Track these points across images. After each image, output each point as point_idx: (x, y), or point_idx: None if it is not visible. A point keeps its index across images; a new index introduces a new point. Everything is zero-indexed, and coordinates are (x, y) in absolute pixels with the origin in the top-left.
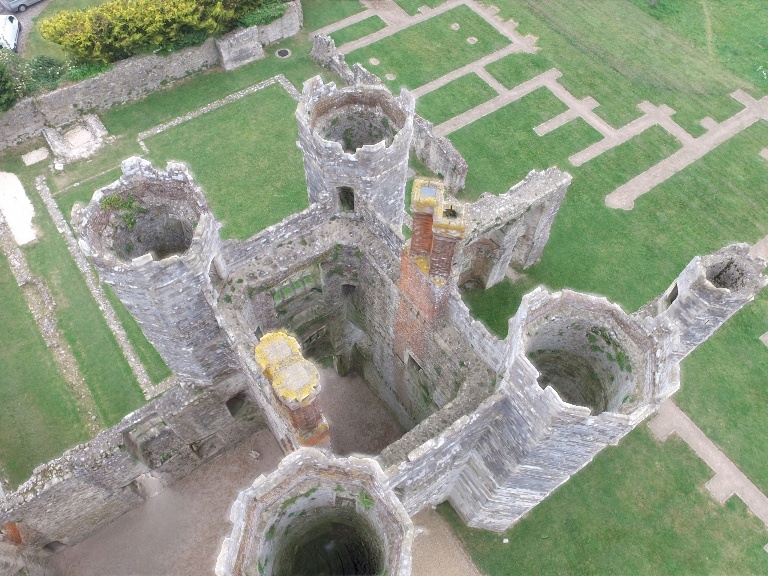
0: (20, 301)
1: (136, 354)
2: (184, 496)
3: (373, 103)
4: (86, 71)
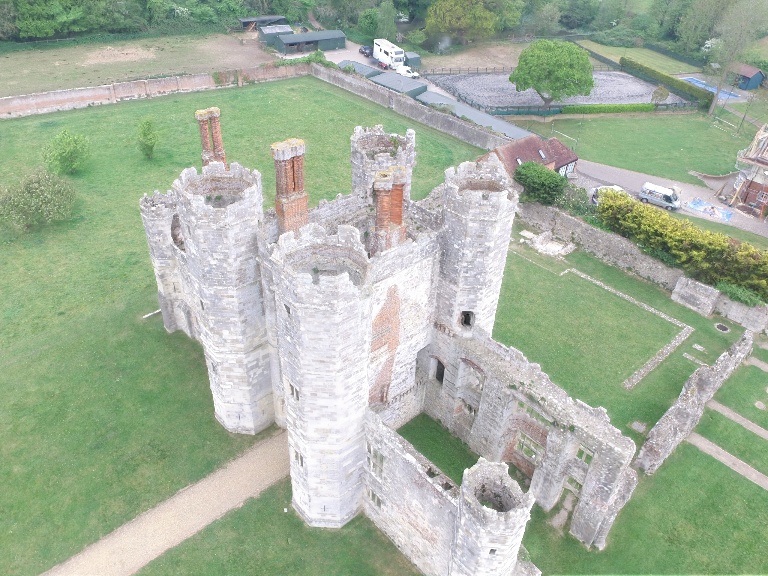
0: None
1: None
2: None
3: None
4: (596, 222)
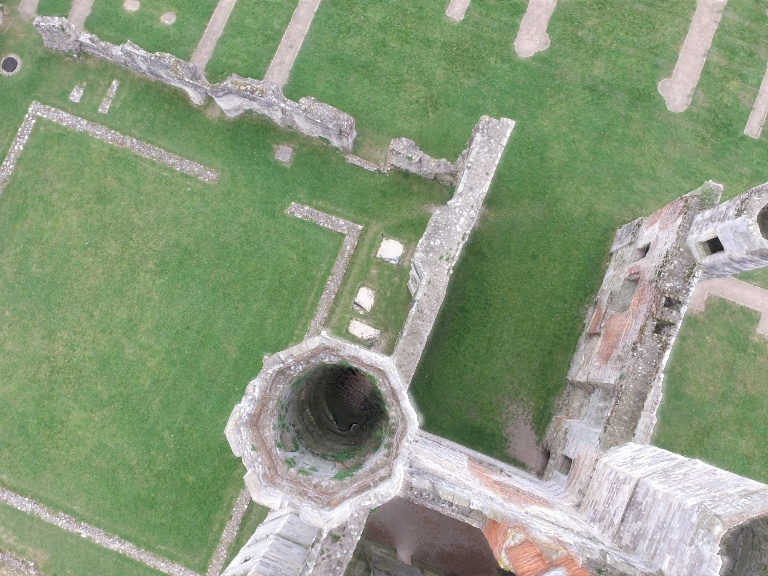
0: None
1: (161, 557)
2: None
3: None
4: None
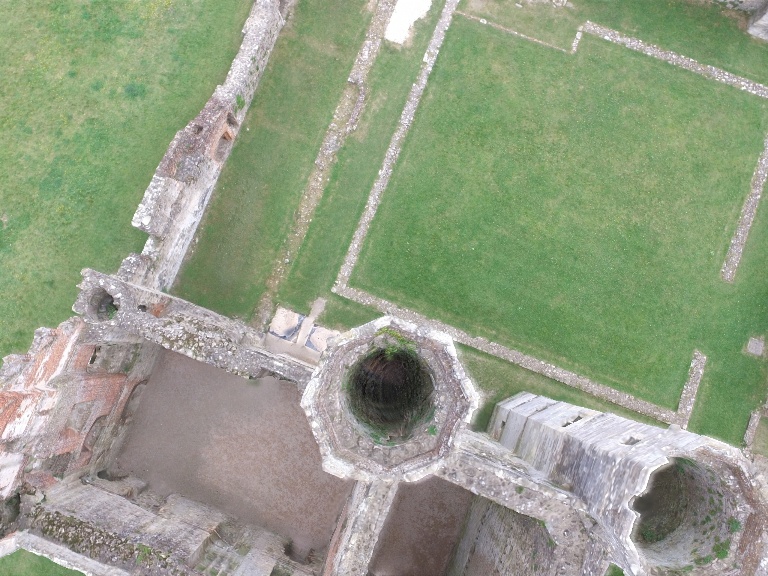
0: (336, 95)
1: (363, 243)
2: (280, 391)
3: (750, 501)
4: None
